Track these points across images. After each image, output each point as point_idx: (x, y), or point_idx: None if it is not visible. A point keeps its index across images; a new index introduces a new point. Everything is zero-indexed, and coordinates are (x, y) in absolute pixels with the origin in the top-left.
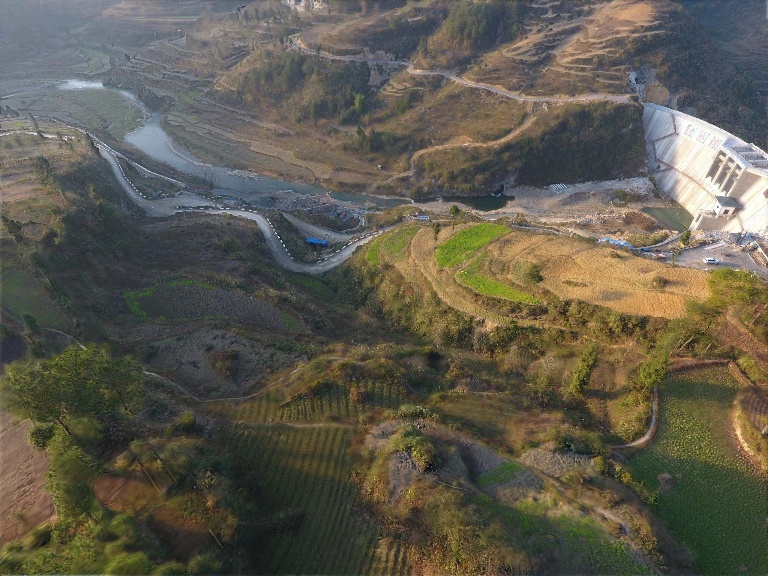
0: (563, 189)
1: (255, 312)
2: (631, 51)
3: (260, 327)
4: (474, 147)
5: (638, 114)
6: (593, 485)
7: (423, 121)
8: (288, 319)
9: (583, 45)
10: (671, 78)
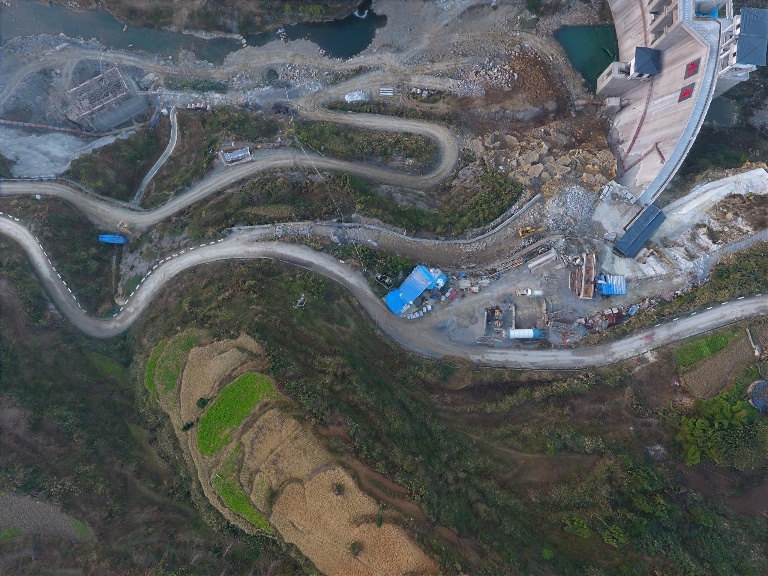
0: None
1: (46, 521)
2: None
3: (55, 545)
4: None
5: None
6: None
7: None
8: (77, 526)
9: None
10: None
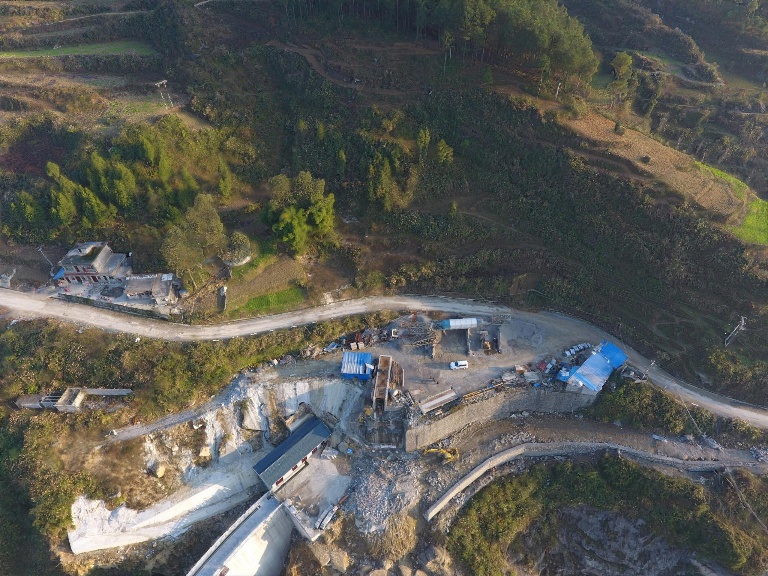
0: None
1: None
2: None
3: None
4: None
5: None
6: (648, 67)
7: None
8: None
9: None
10: None
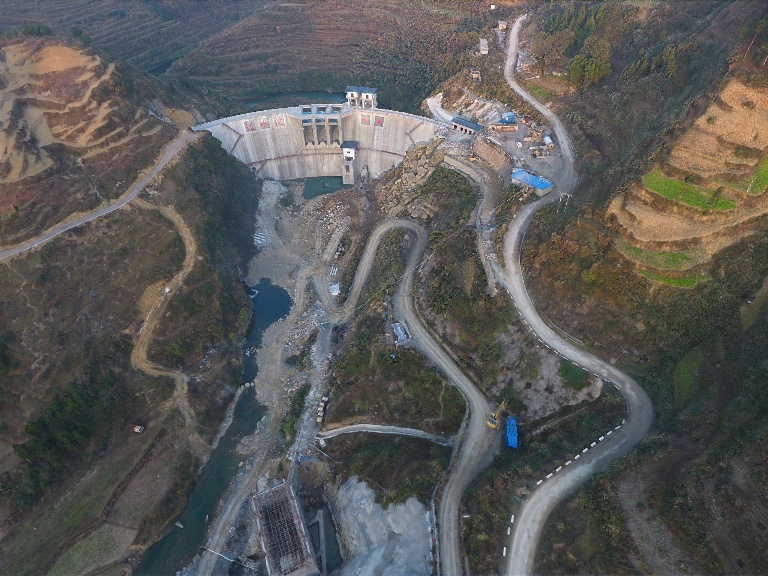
0: (265, 236)
1: None
2: (125, 94)
3: None
4: (186, 281)
5: (216, 139)
6: None
7: (70, 333)
8: None
9: (75, 114)
10: (173, 99)
